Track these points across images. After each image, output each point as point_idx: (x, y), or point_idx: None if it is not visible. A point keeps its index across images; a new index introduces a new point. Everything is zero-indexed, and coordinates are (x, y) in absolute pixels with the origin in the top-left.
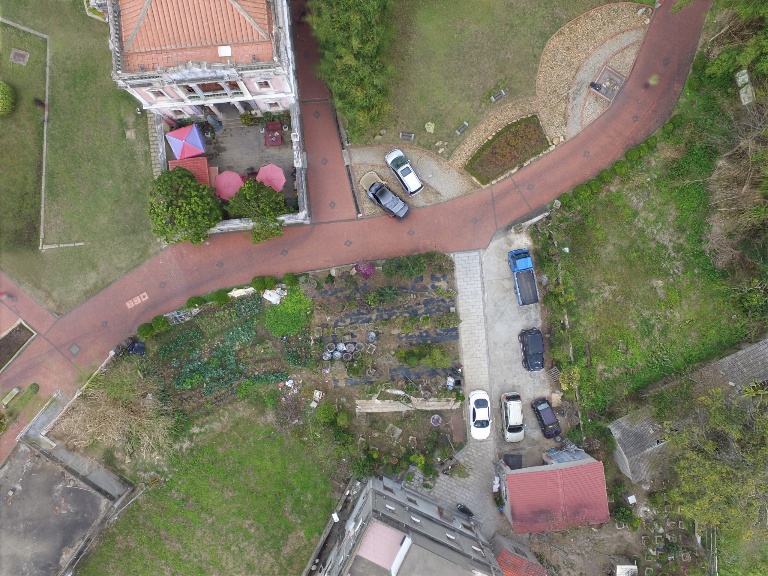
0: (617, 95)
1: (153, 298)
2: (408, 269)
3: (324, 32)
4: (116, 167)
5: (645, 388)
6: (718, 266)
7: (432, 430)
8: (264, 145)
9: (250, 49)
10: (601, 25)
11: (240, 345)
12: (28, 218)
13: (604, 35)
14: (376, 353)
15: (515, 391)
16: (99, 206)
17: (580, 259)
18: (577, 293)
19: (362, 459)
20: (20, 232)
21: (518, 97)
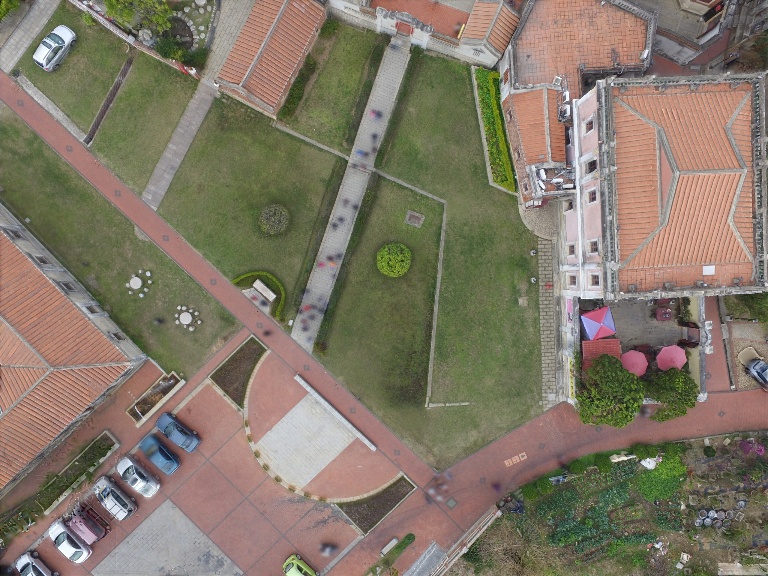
0: None
1: (532, 458)
2: None
3: None
4: (506, 332)
5: None
6: None
7: None
8: (649, 317)
9: (731, 268)
10: None
11: (612, 506)
12: (415, 376)
13: None
14: None
15: None
16: (487, 369)
17: None
18: None
19: None
20: (406, 389)
21: None
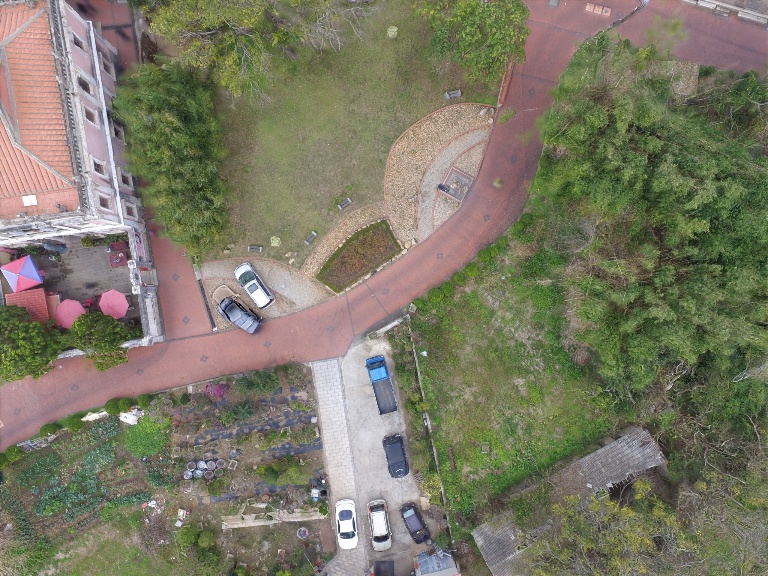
0: (466, 195)
1: (8, 426)
2: (259, 388)
3: (140, 168)
4: None
5: (509, 490)
6: (578, 361)
7: (301, 542)
8: None
9: (57, 196)
10: (445, 127)
11: (100, 468)
12: None
13: (449, 136)
14: (239, 468)
15: (383, 497)
16: None
17: (439, 362)
18: (438, 396)
19: None
20: None
21: (366, 203)
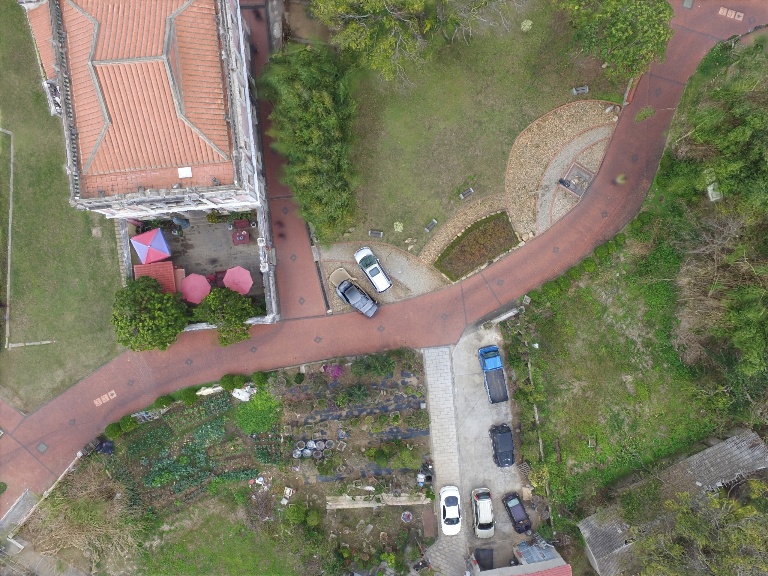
0: (586, 191)
1: (121, 396)
2: (377, 370)
3: (287, 146)
4: (82, 265)
5: (614, 484)
6: (687, 361)
7: (403, 525)
8: (232, 242)
9: (211, 170)
10: (570, 122)
11: (210, 442)
12: None
13: (573, 132)
14: (346, 449)
15: (486, 485)
16: (65, 304)
17: (550, 355)
18: (547, 389)
19: (331, 561)
20: None
21: (487, 193)
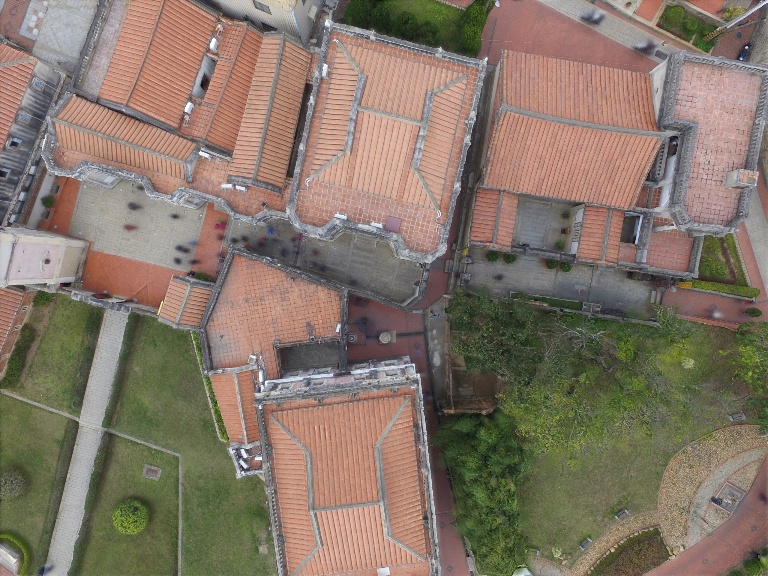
0: (737, 507)
1: None
2: None
3: (472, 526)
4: None
5: None
6: None
7: None
8: None
9: (407, 567)
10: (724, 446)
11: None
12: None
13: (726, 454)
14: None
15: None
16: None
17: None
18: None
19: None
20: None
21: (640, 511)
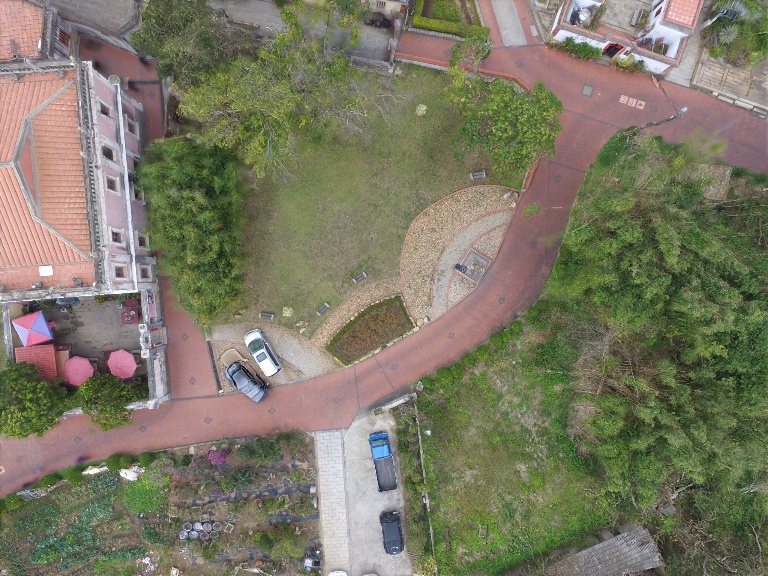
0: (483, 277)
1: (10, 472)
2: (261, 458)
3: (158, 241)
4: None
5: (503, 575)
6: (582, 452)
7: None
8: None
9: (73, 268)
10: (466, 207)
11: (97, 520)
12: None
13: (470, 217)
14: (235, 531)
15: (376, 571)
16: None
17: (442, 442)
18: (439, 476)
19: None
20: None
21: (382, 277)
